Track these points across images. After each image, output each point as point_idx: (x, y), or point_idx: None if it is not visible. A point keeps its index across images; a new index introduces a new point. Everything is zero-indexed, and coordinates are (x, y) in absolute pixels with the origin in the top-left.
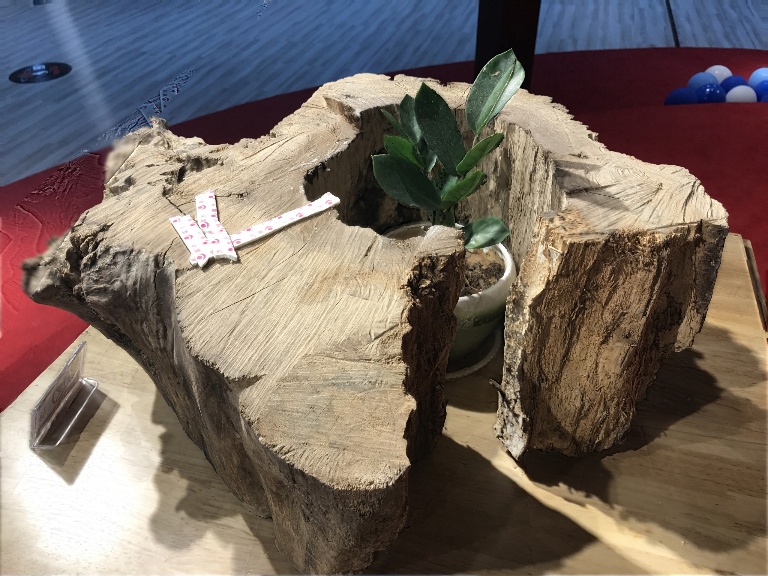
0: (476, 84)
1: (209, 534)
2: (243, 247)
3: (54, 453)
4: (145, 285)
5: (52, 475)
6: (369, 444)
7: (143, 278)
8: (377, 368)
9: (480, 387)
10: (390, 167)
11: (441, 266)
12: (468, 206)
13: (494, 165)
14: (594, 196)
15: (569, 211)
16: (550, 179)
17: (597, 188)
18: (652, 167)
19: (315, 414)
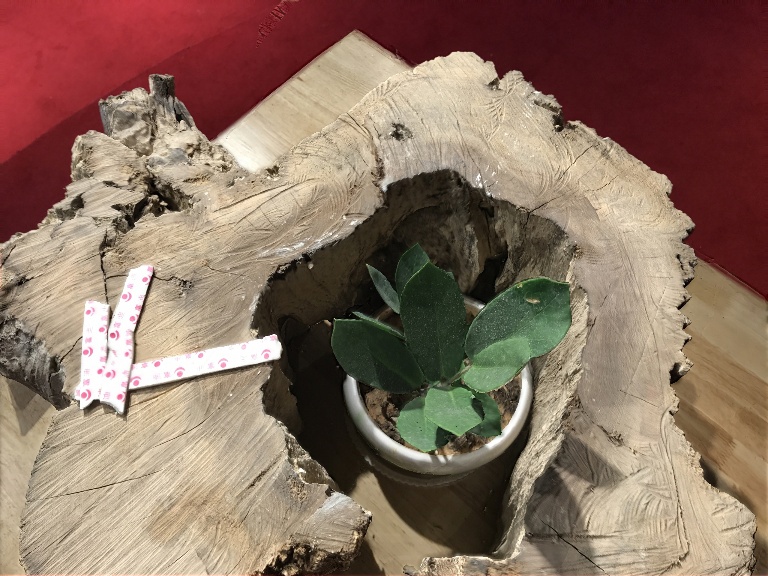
0: (500, 300)
1: None
2: (140, 390)
3: (22, 390)
4: (41, 379)
5: (12, 416)
6: None
7: (39, 372)
8: None
9: (438, 498)
10: (358, 335)
11: (316, 561)
12: None
13: None
14: (565, 550)
15: (508, 570)
16: (554, 446)
17: (579, 536)
18: (705, 500)
19: None
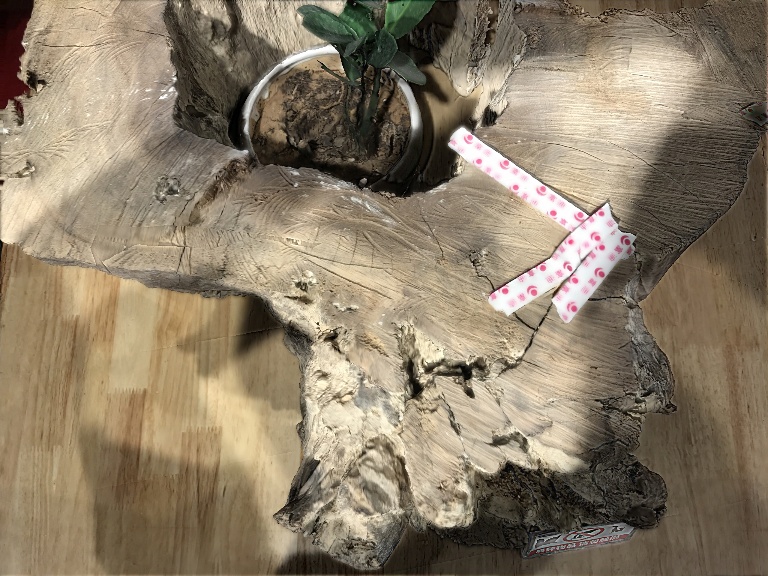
0: None
1: (640, 303)
2: None
3: None
4: None
5: None
6: (766, 19)
7: None
8: (699, 27)
9: None
10: None
11: None
12: (218, 102)
13: (211, 30)
14: None
15: None
16: None
17: None
18: None
19: (765, 59)
